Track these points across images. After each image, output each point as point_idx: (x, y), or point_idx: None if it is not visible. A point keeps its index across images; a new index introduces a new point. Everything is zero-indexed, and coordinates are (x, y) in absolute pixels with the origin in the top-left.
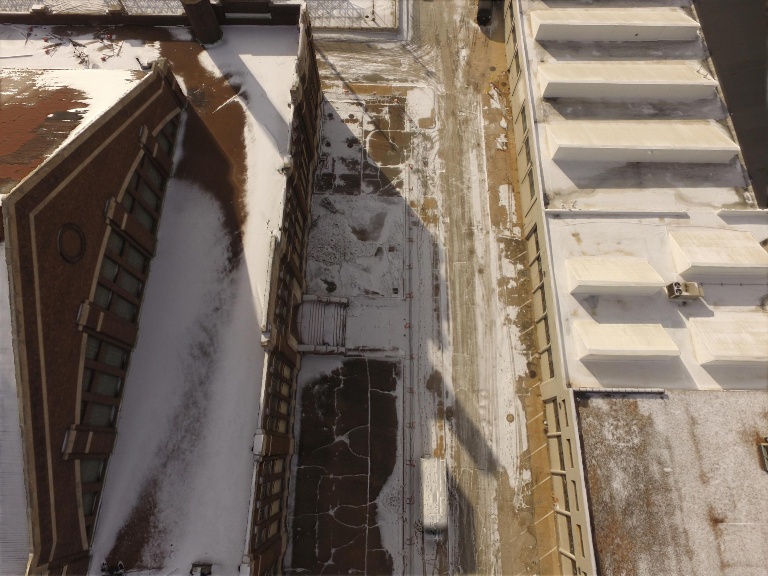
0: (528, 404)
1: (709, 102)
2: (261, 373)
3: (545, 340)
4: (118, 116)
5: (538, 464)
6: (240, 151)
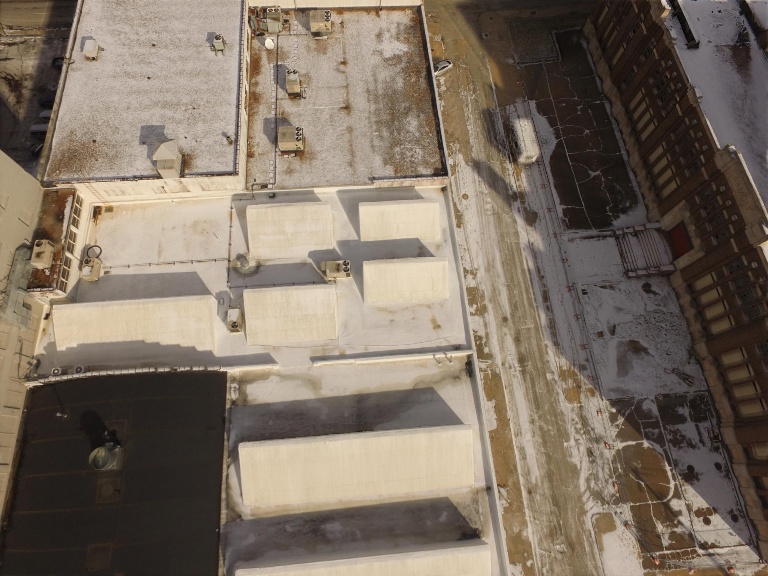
0: None
1: (243, 555)
2: None
3: None
4: None
5: None
6: None
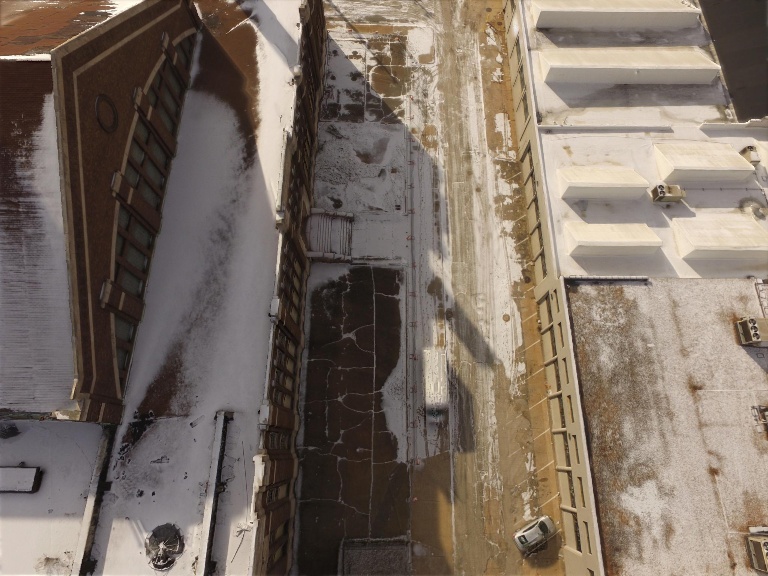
0: (523, 306)
1: (693, 30)
2: (275, 254)
3: (538, 246)
4: (144, 14)
5: (532, 357)
6: (252, 66)
